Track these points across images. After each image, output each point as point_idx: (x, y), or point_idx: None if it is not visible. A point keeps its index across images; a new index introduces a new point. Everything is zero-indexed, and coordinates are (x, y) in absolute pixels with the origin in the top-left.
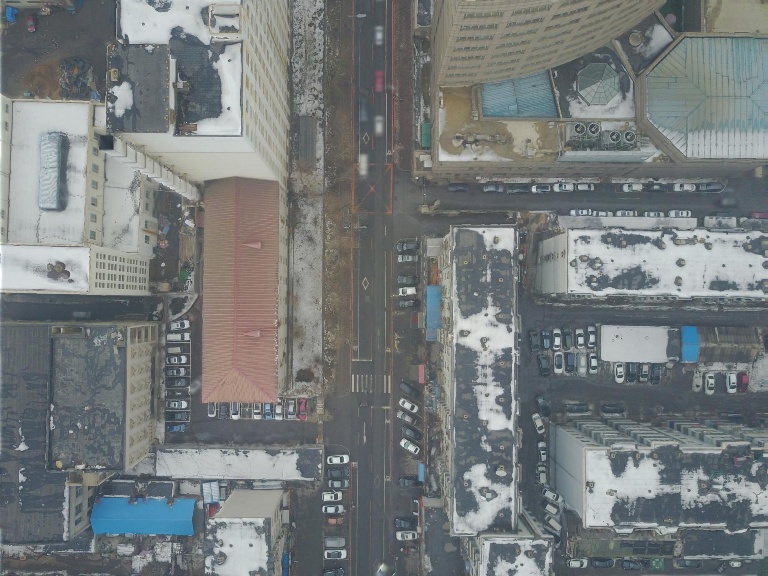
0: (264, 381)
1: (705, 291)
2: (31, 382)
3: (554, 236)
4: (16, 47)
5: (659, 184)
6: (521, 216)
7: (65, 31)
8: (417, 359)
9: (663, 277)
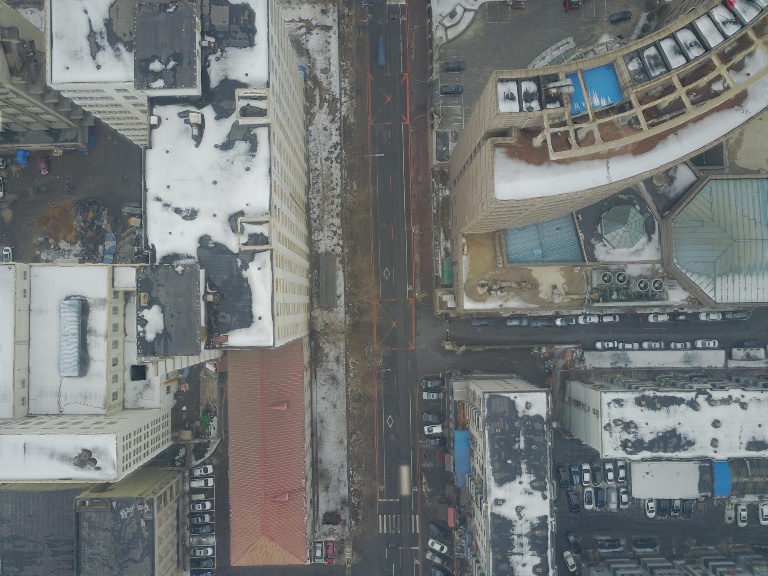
0: (294, 544)
1: (742, 452)
2: (56, 549)
3: (582, 376)
4: (29, 189)
5: (685, 314)
6: (546, 350)
7: (78, 172)
8: (445, 498)
9: (699, 439)
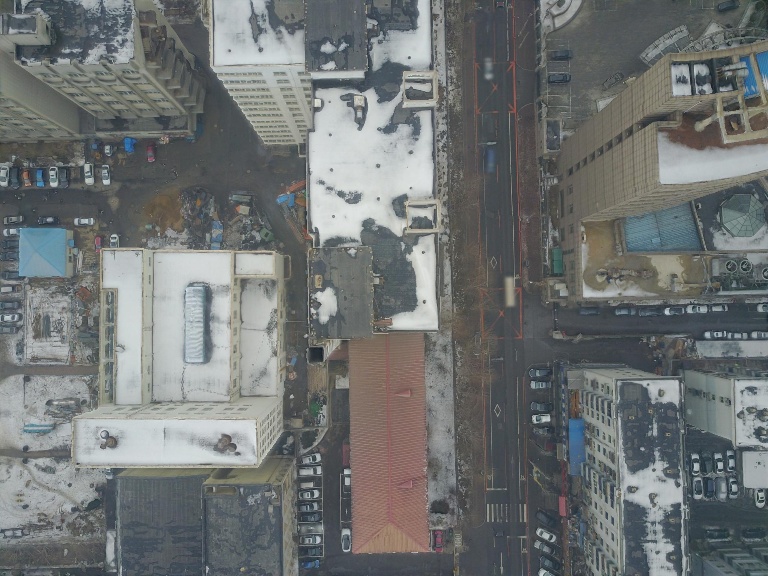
0: (417, 532)
1: None
2: (176, 535)
3: (696, 365)
4: (135, 177)
5: None
6: (655, 340)
7: (184, 160)
8: (553, 487)
9: None
